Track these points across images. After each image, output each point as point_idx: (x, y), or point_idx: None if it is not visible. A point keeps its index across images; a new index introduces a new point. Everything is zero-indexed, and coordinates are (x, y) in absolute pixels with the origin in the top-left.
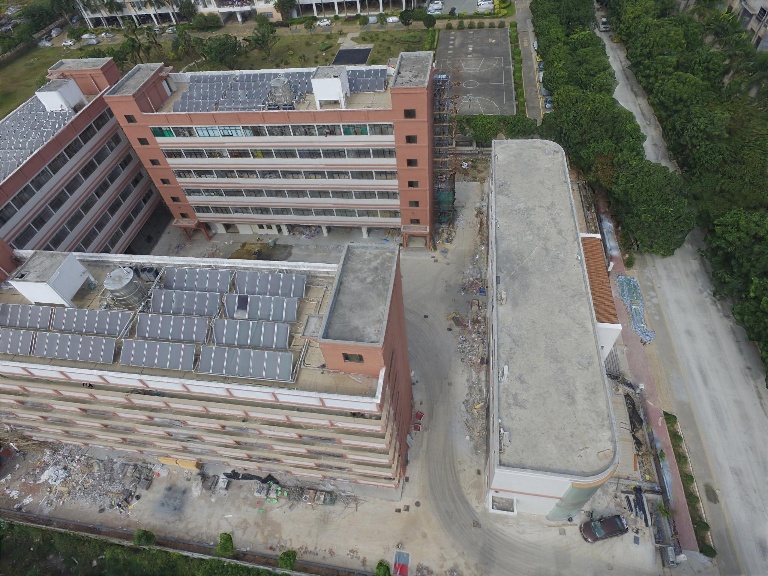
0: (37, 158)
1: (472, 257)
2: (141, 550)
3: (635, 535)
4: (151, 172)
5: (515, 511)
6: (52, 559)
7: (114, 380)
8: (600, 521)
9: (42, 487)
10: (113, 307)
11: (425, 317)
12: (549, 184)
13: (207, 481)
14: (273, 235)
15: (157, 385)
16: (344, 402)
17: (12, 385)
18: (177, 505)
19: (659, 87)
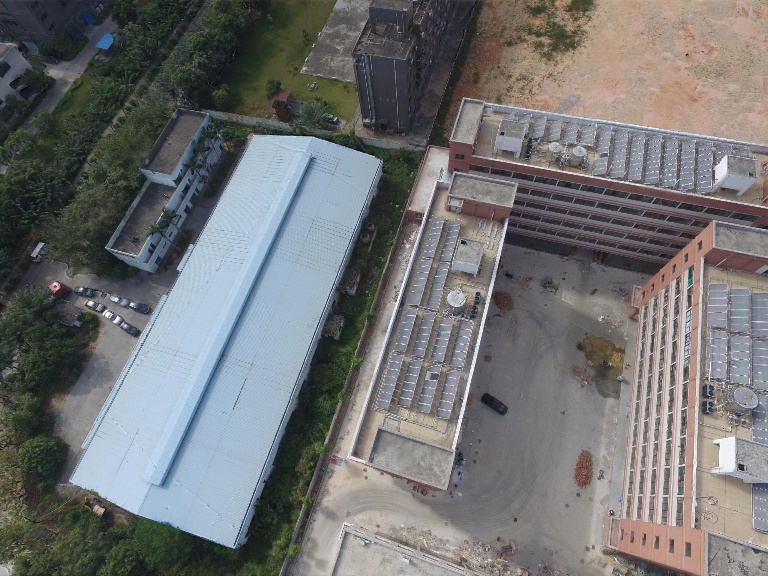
0: (633, 187)
1: None
2: None
3: None
4: None
5: None
6: (375, 269)
7: None
8: None
9: None
10: None
11: (515, 519)
12: None
13: None
14: None
15: None
16: None
17: None
18: None
19: None
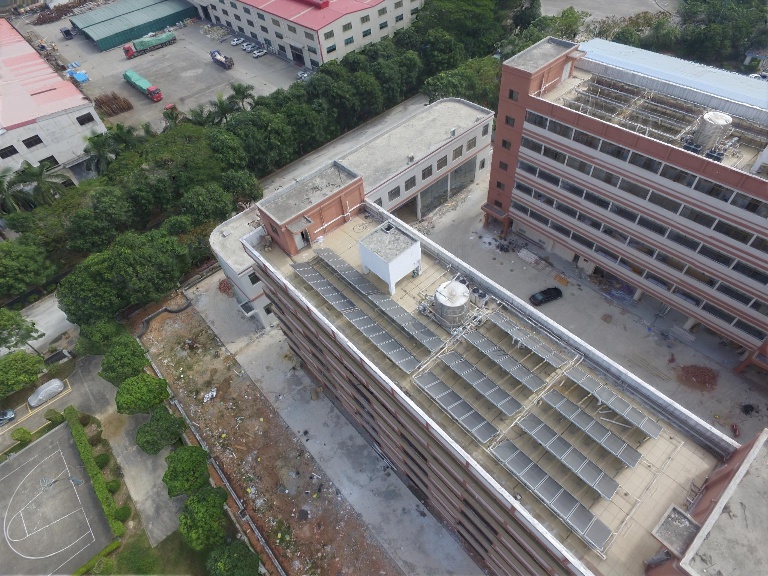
0: None
1: None
2: None
3: None
4: None
5: None
6: None
7: None
8: None
9: None
10: (726, 142)
11: None
12: None
13: None
14: None
15: None
16: None
17: None
18: None
19: (8, 276)
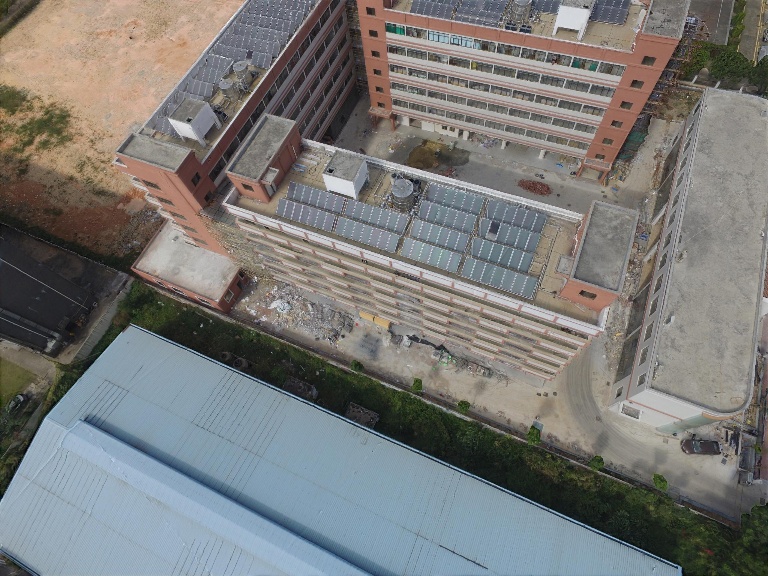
0: (294, 42)
1: (641, 200)
2: (349, 373)
3: (724, 458)
4: (368, 61)
5: (639, 419)
6: (285, 362)
7: (398, 266)
8: (700, 442)
9: (272, 312)
10: (388, 207)
11: None
12: (754, 151)
13: (395, 338)
14: (453, 137)
15: (430, 278)
16: (574, 324)
17: (308, 248)
18: (373, 349)
19: None
